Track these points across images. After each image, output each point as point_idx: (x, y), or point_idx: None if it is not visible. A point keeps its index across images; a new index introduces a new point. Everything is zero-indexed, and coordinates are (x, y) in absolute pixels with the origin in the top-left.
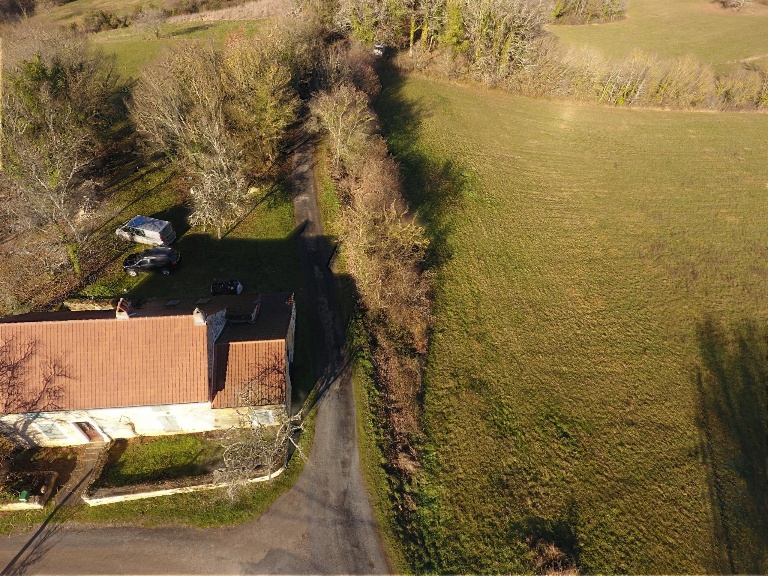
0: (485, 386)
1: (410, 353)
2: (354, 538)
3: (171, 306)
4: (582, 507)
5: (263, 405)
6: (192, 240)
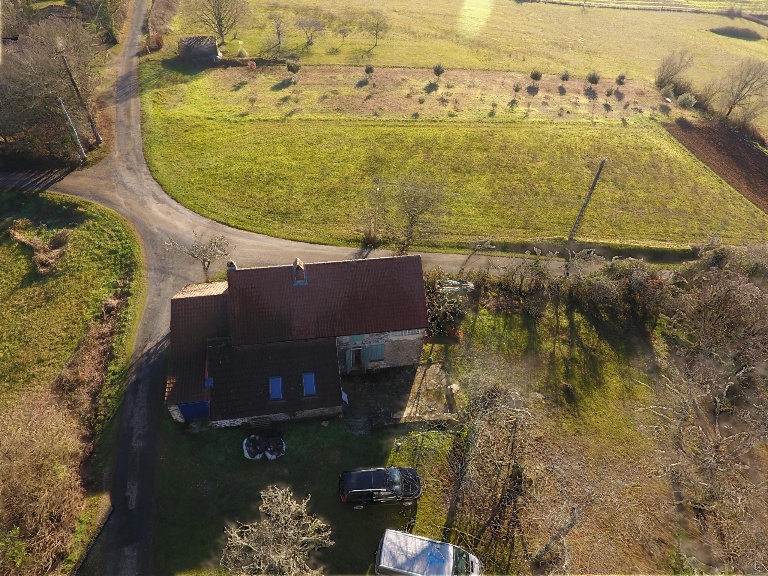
0: (3, 375)
1: (61, 390)
2: (162, 262)
3: (306, 371)
4: (0, 297)
5: (203, 283)
6: (348, 573)
